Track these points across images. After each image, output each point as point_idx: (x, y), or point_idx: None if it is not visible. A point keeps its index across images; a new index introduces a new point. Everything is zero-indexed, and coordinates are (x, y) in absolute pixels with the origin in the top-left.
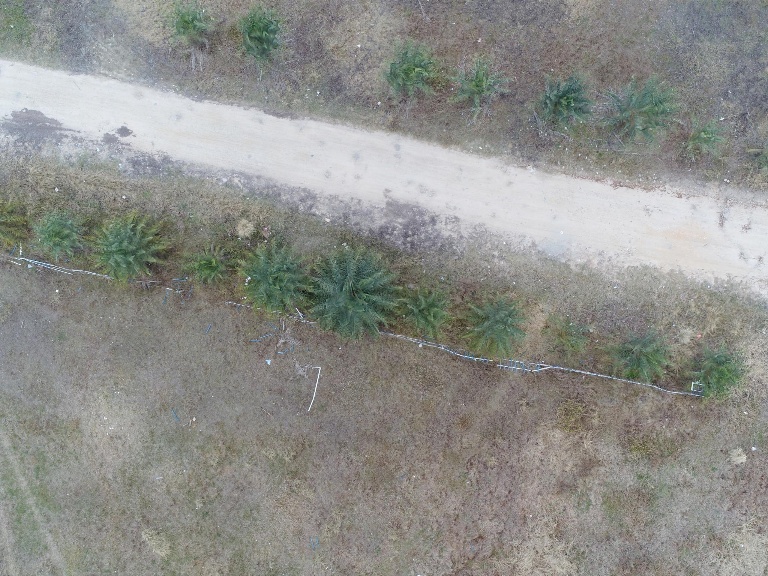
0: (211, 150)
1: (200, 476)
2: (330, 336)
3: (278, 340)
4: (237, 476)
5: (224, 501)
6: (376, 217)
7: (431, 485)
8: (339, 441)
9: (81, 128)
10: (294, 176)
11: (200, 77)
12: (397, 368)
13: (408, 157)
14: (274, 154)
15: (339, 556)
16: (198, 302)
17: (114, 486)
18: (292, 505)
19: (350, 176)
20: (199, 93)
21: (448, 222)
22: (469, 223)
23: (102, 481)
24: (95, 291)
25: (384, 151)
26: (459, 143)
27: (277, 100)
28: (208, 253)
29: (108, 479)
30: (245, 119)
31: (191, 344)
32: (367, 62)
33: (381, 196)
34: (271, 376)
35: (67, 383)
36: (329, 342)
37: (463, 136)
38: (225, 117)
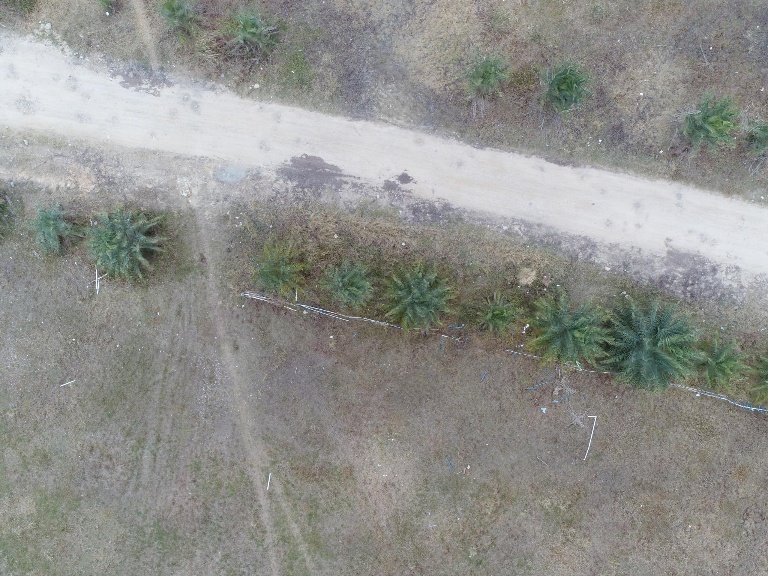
0: (492, 198)
1: (474, 524)
2: (607, 385)
3: (554, 388)
4: (511, 525)
5: (498, 550)
6: (656, 266)
7: (707, 535)
8: (614, 490)
9: (361, 174)
10: (575, 224)
11: (481, 124)
12: (674, 417)
13: (690, 206)
14: (555, 202)
15: None
16: (474, 349)
17: (387, 534)
18: (567, 554)
19: (631, 225)
20: (480, 140)
21: (728, 272)
22: (750, 273)
23: (375, 528)
24: (370, 337)
25: (666, 200)
26: (741, 193)
27: (559, 148)
28: (491, 301)
29: (381, 526)
30: (526, 167)
31: (466, 392)
32: (649, 110)
33: (662, 245)
34: (546, 424)
35: (341, 430)
36: (605, 391)
37: (745, 185)
38: (506, 164)
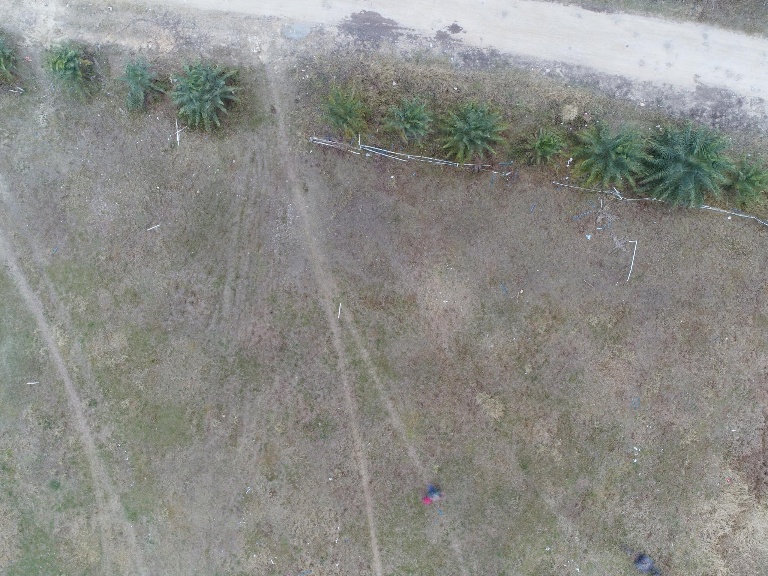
0: (535, 43)
1: (529, 343)
2: (645, 212)
3: (597, 217)
4: (563, 343)
5: (551, 366)
6: (687, 101)
7: (743, 346)
8: (656, 308)
9: (415, 26)
10: (611, 65)
11: None
12: (708, 239)
13: (715, 45)
14: (593, 45)
15: (659, 414)
16: (522, 184)
17: (449, 355)
18: (614, 368)
19: (662, 64)
20: None
21: (753, 103)
22: None
23: (438, 350)
24: (427, 176)
25: (693, 40)
26: (762, 31)
27: None
28: (537, 136)
29: (444, 348)
30: (565, 14)
31: (517, 222)
32: None
33: (691, 81)
34: (591, 250)
35: (404, 261)
36: (644, 217)
37: (765, 24)
38: (547, 13)
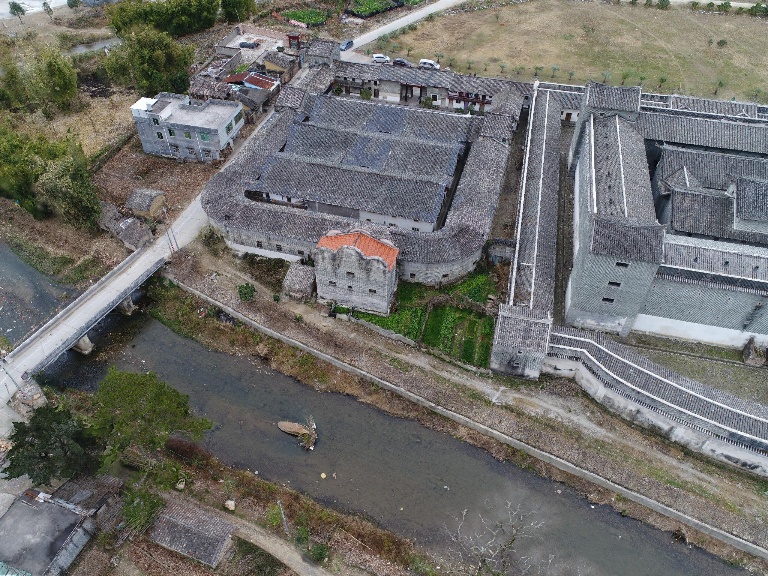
0: None
1: None
2: None
3: None
4: None
5: None
6: None
7: None
8: None
9: None
10: None
11: None
12: None
13: None
14: (743, 5)
15: None
16: None
17: None
18: None
19: None
20: None
21: None
22: None
23: None
24: None
25: None
26: None
27: None
28: None
29: None
30: None
31: None
32: None
33: None
34: None
35: None
36: None
37: None
38: None
